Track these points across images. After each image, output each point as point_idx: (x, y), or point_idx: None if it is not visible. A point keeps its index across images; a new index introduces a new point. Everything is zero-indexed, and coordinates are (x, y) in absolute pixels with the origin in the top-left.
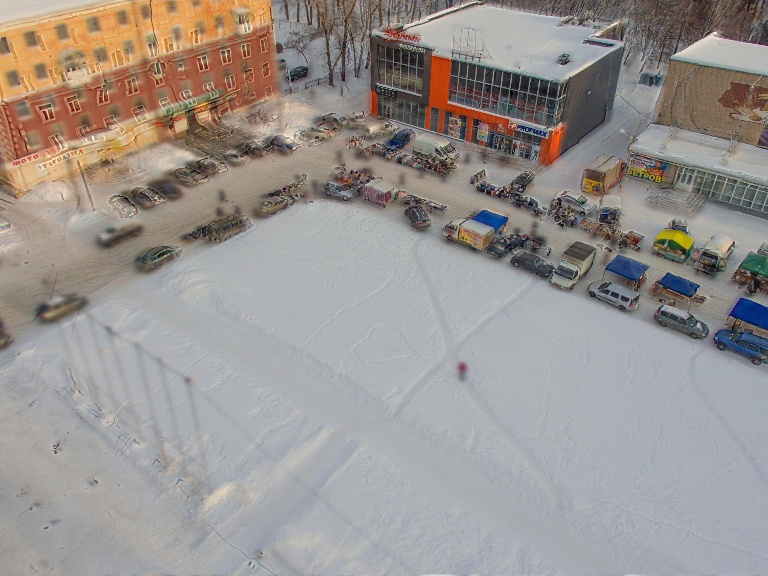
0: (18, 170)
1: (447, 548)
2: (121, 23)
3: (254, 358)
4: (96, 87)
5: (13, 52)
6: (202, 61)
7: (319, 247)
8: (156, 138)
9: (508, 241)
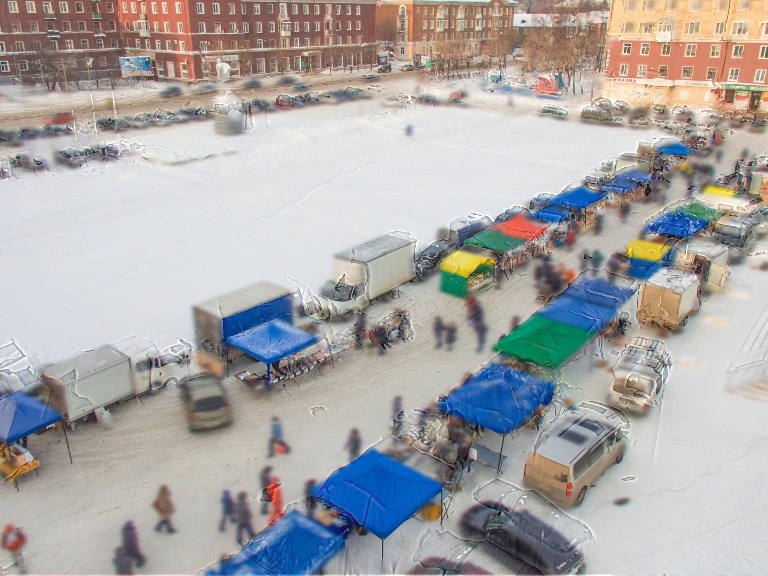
0: (596, 76)
1: (353, 138)
2: (704, 4)
3: (475, 126)
4: (663, 42)
5: (626, 7)
6: (766, 50)
7: (593, 128)
8: (693, 95)
9: (647, 153)
